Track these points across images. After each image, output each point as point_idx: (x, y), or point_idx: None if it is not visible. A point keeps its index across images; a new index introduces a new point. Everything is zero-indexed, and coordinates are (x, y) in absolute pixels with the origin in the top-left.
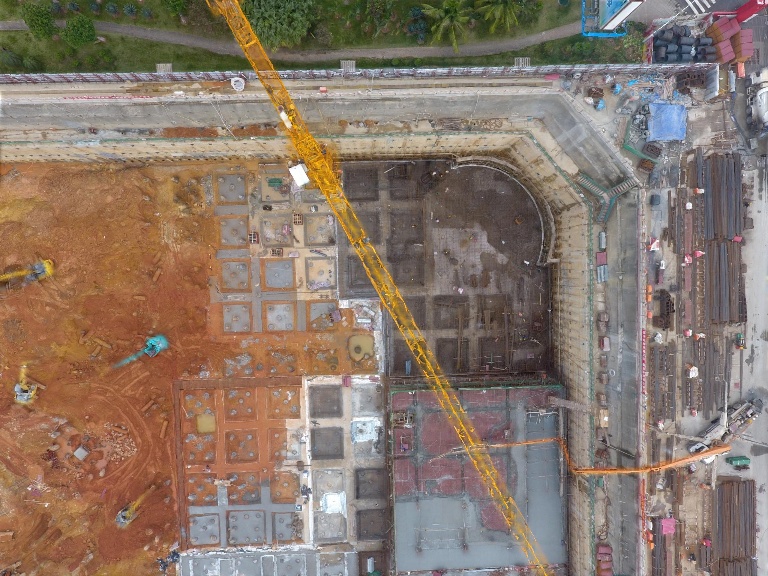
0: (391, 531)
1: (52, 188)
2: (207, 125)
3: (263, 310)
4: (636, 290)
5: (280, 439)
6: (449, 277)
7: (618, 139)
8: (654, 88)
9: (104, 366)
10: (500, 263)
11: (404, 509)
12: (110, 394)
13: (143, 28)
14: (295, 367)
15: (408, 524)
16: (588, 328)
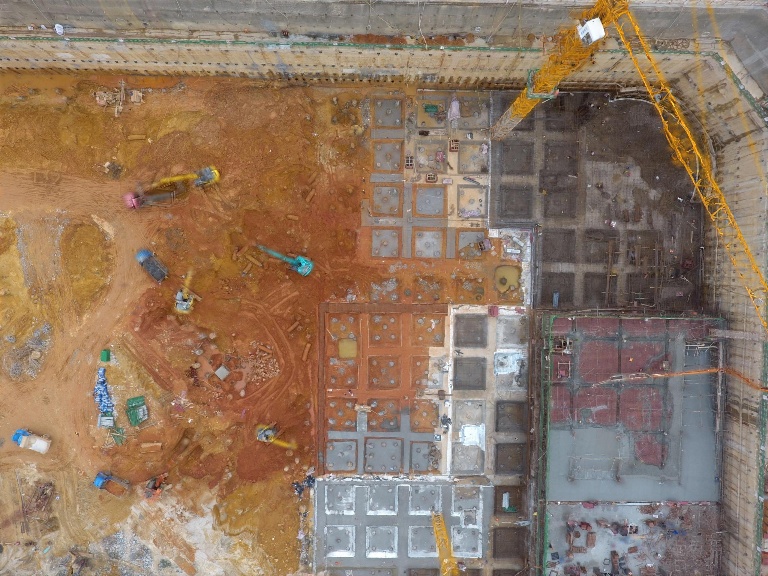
0: (530, 466)
1: (218, 102)
2: (397, 33)
3: (413, 236)
4: None
5: (421, 367)
6: (601, 211)
7: None
8: None
9: (255, 284)
10: (652, 199)
11: (557, 437)
12: (260, 311)
13: None
14: (441, 295)
15: (561, 453)
16: (765, 255)
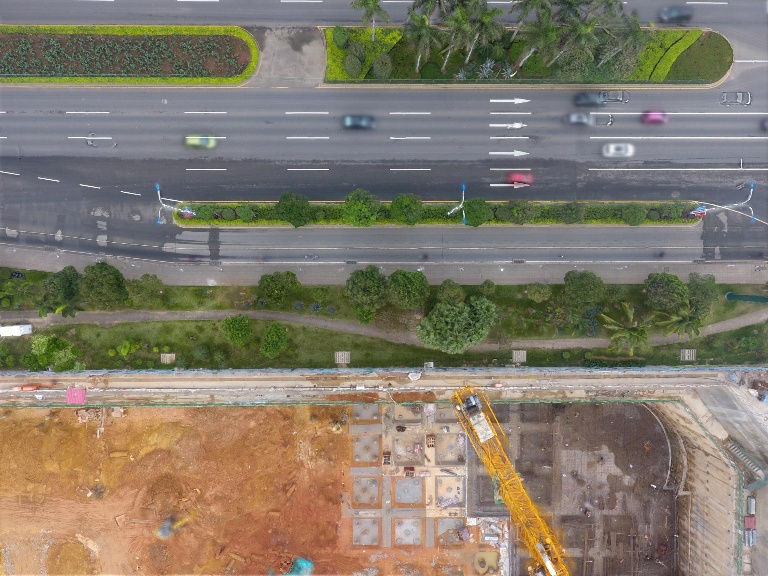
0: None
1: (198, 414)
2: None
3: (392, 525)
4: None
5: None
6: (576, 498)
7: None
8: None
9: None
10: (626, 485)
11: None
12: None
13: (324, 319)
14: None
15: None
16: None
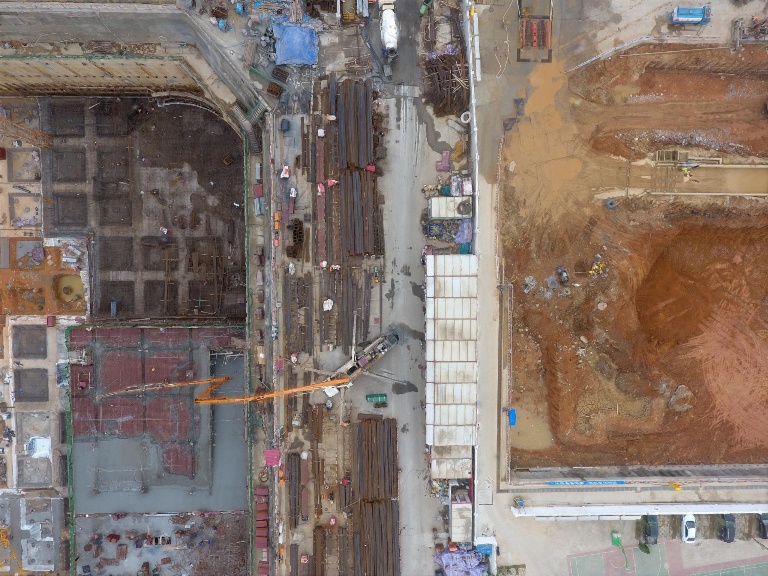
0: None
1: None
2: None
3: None
4: (269, 219)
5: None
6: (157, 218)
7: (246, 61)
8: (283, 10)
9: None
10: (211, 205)
11: (82, 449)
12: None
13: None
14: (0, 306)
15: (86, 465)
16: None
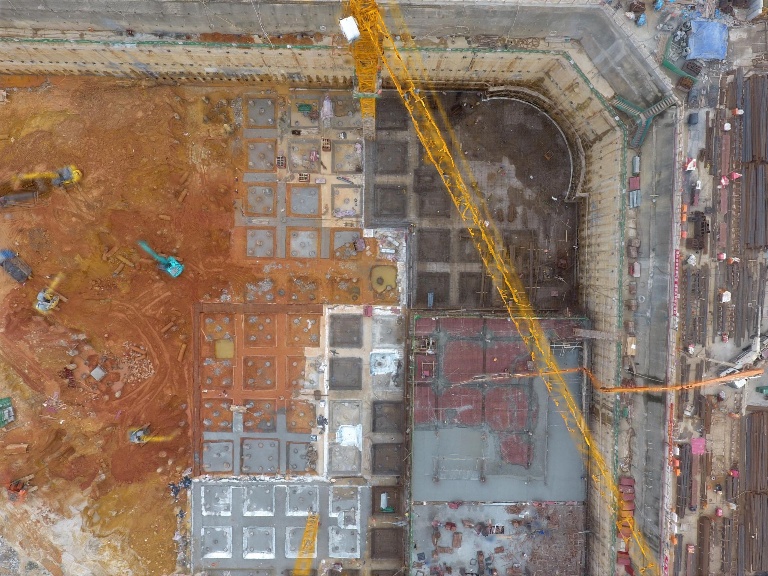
0: (406, 466)
1: (84, 101)
2: (244, 32)
3: (287, 236)
4: (670, 211)
5: (298, 368)
6: None
7: (658, 56)
8: (696, 6)
9: (126, 284)
10: (527, 198)
11: (422, 437)
12: (131, 312)
13: None
14: (316, 295)
15: (426, 453)
16: (618, 254)
